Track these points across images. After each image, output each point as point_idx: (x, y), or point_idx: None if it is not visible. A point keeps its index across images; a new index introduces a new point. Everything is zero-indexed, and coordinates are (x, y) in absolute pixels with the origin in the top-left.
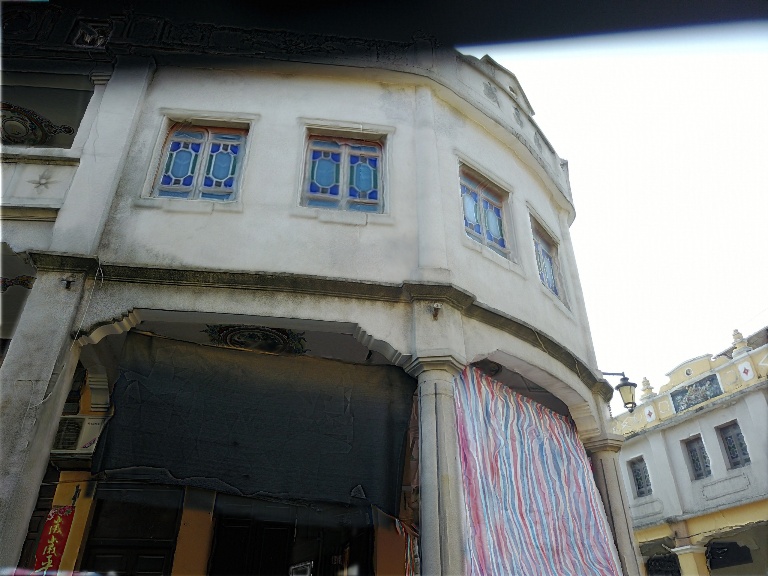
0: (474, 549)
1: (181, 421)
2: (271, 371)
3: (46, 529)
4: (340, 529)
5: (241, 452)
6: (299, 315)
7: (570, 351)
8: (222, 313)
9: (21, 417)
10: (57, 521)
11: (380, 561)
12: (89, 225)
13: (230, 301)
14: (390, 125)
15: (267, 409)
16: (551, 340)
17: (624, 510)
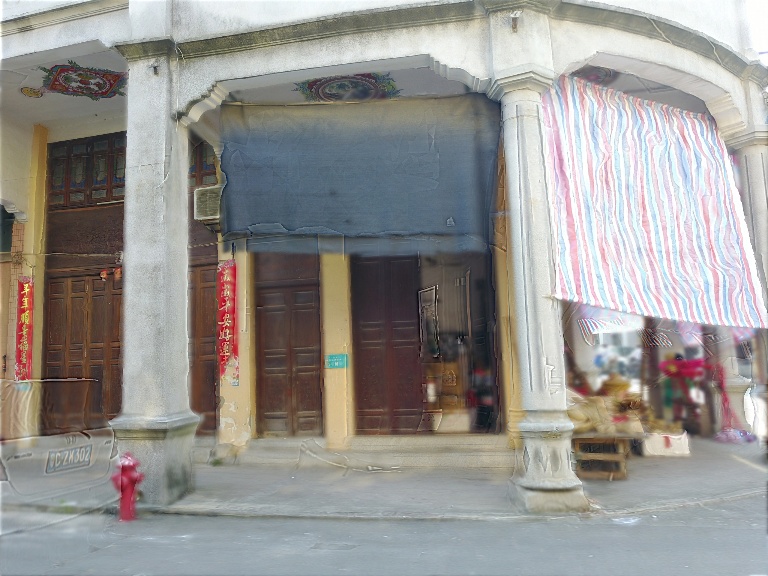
0: (563, 264)
1: (282, 181)
2: (354, 120)
3: (218, 279)
4: (460, 256)
5: (338, 201)
6: (368, 57)
7: (703, 34)
8: (294, 70)
9: (152, 196)
10: (225, 272)
11: (498, 280)
12: (157, 4)
13: (299, 56)
14: None
15: (354, 158)
16: (674, 26)
17: (767, 207)
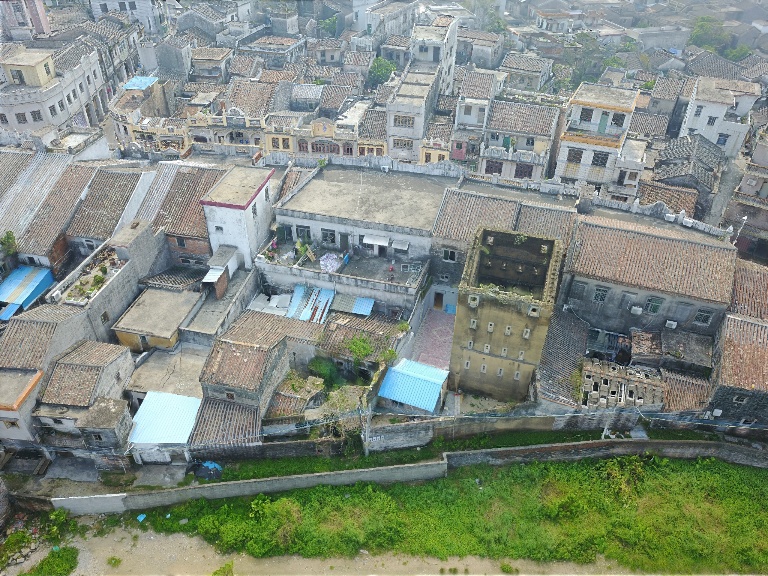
0: None
1: None
2: None
3: None
4: None
5: None
6: None
7: None
8: None
9: None
10: None
11: None
12: None
13: None
14: (5, 112)
15: None
16: None
17: None
